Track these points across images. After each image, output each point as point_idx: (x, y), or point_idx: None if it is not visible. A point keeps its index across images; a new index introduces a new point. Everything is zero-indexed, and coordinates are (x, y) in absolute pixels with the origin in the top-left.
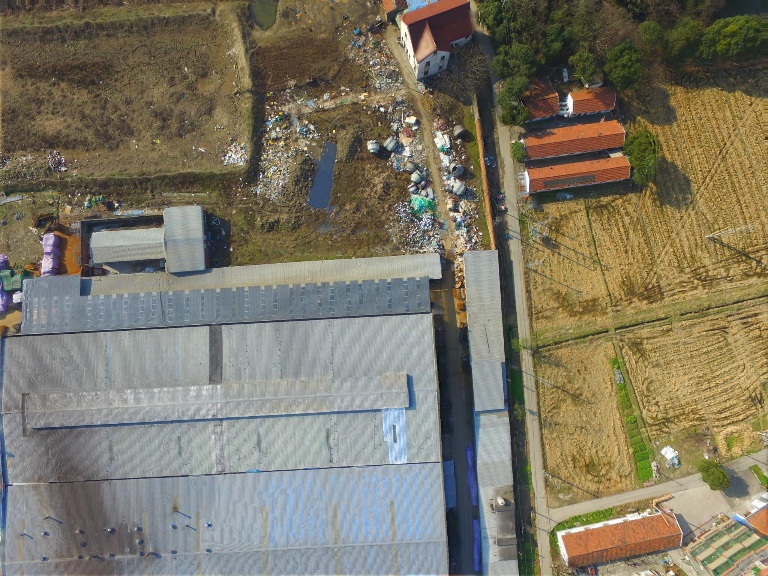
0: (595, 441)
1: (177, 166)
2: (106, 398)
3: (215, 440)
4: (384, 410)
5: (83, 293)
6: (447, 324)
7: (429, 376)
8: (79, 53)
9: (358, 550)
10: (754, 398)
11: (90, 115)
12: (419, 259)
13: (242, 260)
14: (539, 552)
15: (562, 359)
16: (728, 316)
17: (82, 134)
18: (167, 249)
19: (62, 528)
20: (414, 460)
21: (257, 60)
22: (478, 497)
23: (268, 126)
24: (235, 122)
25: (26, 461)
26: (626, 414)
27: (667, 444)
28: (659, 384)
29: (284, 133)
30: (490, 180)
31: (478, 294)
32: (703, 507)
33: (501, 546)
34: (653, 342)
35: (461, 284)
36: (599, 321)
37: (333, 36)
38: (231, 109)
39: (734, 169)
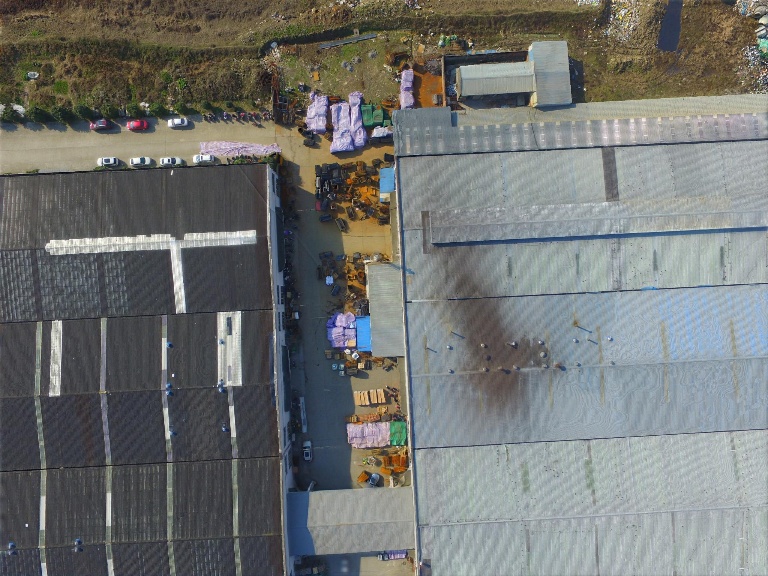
0: None
1: (531, 6)
2: (510, 214)
3: (612, 258)
4: None
5: (453, 124)
6: None
7: None
8: None
9: (756, 363)
10: None
11: None
12: None
13: (595, 100)
14: None
15: None
16: None
17: None
18: (537, 82)
19: (464, 343)
20: None
21: None
22: None
23: None
24: None
25: (425, 278)
26: None
27: None
28: None
29: None
30: None
31: None
32: None
33: None
34: None
35: None
36: None
37: None
38: None
39: None
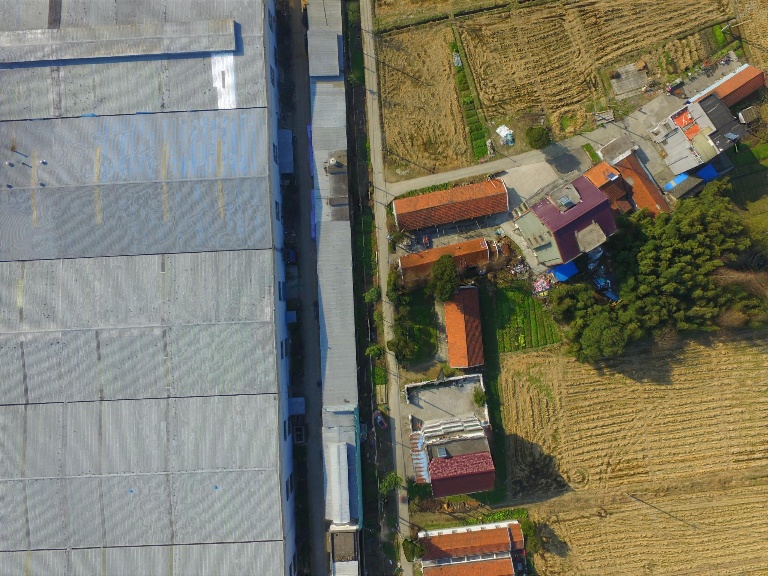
0: (433, 121)
1: None
2: None
3: (52, 85)
4: (212, 54)
5: None
6: (292, 9)
7: (257, 24)
8: None
9: (185, 185)
10: (589, 82)
11: None
12: None
13: None
14: (376, 224)
15: (403, 43)
16: (565, 4)
17: None
18: None
19: None
20: (242, 105)
21: None
22: (313, 161)
23: None
24: None
25: None
26: (463, 95)
27: (502, 123)
28: (496, 67)
29: None
30: None
31: None
32: (535, 181)
33: (334, 207)
34: (492, 28)
35: None
36: (439, 7)
37: None
38: None
39: None
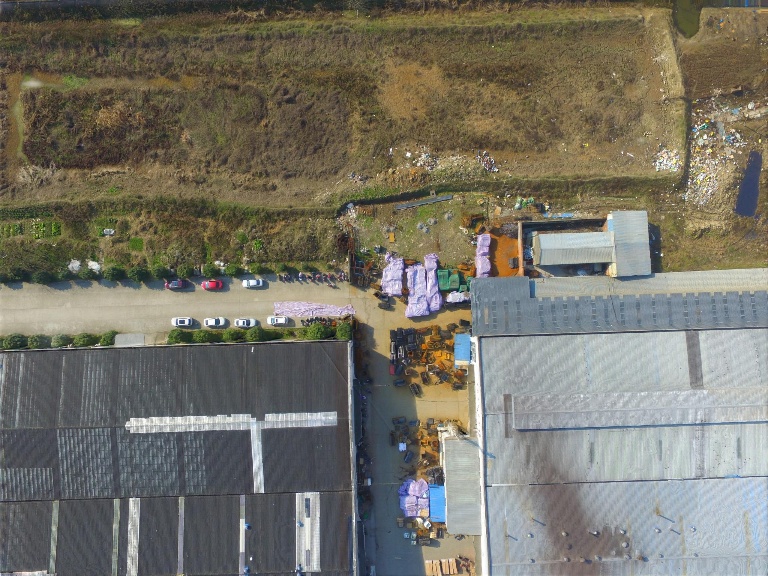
0: None
1: (609, 170)
2: (594, 401)
3: (696, 445)
4: None
5: (532, 295)
6: None
7: None
8: (506, 54)
9: None
10: None
11: (519, 117)
12: None
13: (672, 266)
14: None
15: None
16: None
17: (512, 135)
18: (616, 253)
19: (545, 530)
20: None
21: (684, 67)
22: None
23: (695, 133)
24: (664, 128)
25: (506, 462)
26: None
27: None
28: None
29: (710, 141)
30: None
31: None
32: None
33: None
34: None
35: None
36: None
37: (756, 46)
38: (659, 115)
39: None
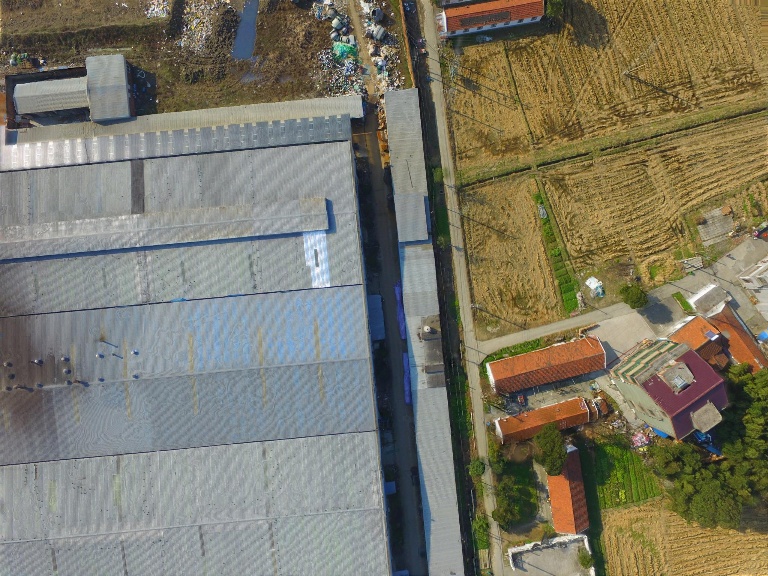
0: (521, 275)
1: (101, 21)
2: (29, 231)
3: (139, 271)
4: (304, 233)
5: (8, 143)
6: (372, 166)
7: (348, 200)
8: None
9: (283, 371)
10: (675, 228)
11: None
12: (341, 100)
13: (168, 111)
14: (469, 384)
15: (486, 197)
16: (647, 150)
17: None
18: (90, 97)
19: None
20: (336, 283)
21: None
22: (405, 327)
23: None
24: None
25: None
26: (550, 247)
27: (591, 275)
28: (582, 217)
29: None
30: (409, 23)
31: (399, 130)
32: (628, 334)
33: (429, 374)
34: (575, 177)
35: (384, 124)
36: (521, 158)
37: None
38: None
39: (649, 8)
